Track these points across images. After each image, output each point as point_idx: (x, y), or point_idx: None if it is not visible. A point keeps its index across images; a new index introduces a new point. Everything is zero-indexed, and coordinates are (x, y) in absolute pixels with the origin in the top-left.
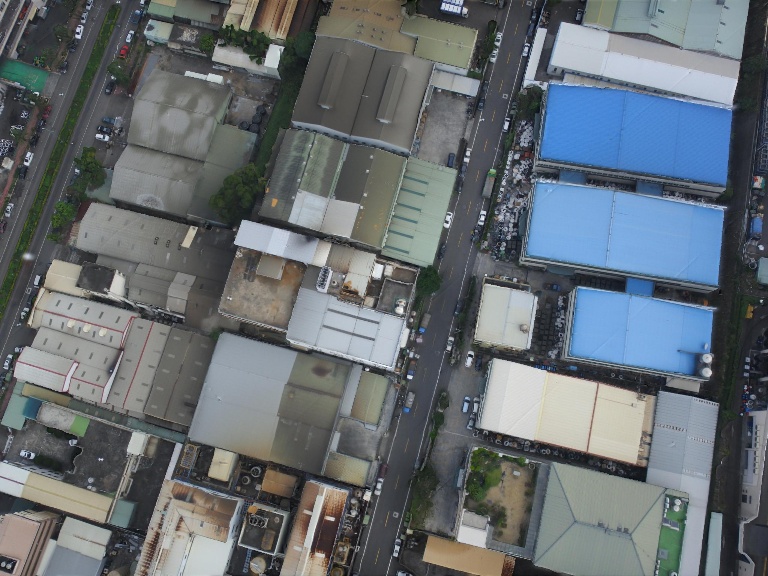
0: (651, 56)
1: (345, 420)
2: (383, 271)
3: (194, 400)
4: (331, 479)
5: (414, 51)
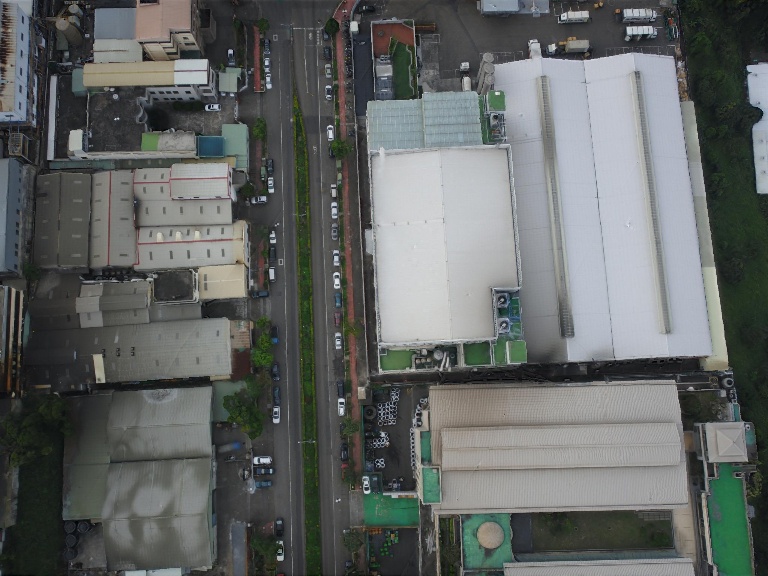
0: None
1: None
2: None
3: (40, 201)
4: None
5: None
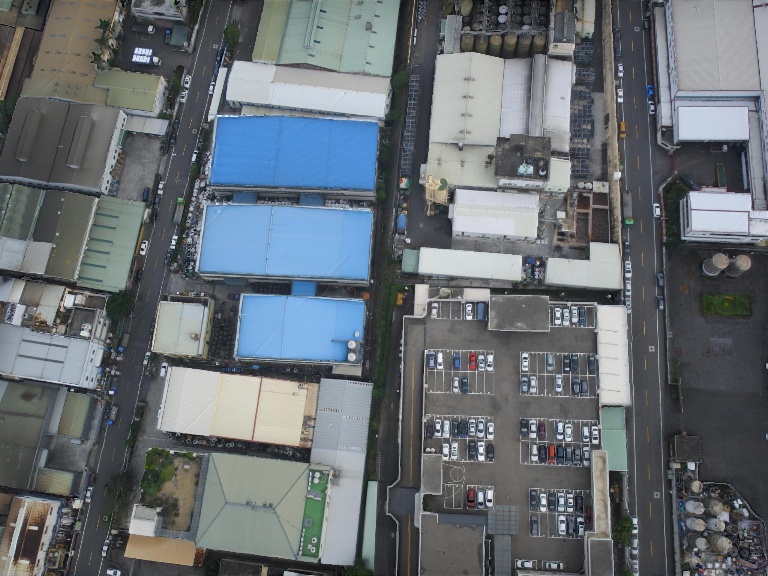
0: (311, 82)
1: (58, 438)
2: (74, 300)
3: None
4: (42, 493)
5: (106, 101)
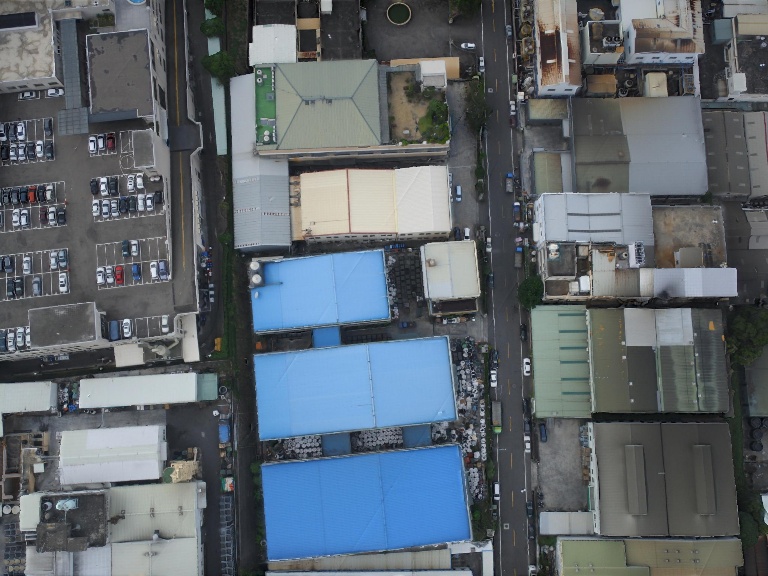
0: None
1: None
2: (580, 285)
3: None
4: (558, 99)
5: (626, 547)
